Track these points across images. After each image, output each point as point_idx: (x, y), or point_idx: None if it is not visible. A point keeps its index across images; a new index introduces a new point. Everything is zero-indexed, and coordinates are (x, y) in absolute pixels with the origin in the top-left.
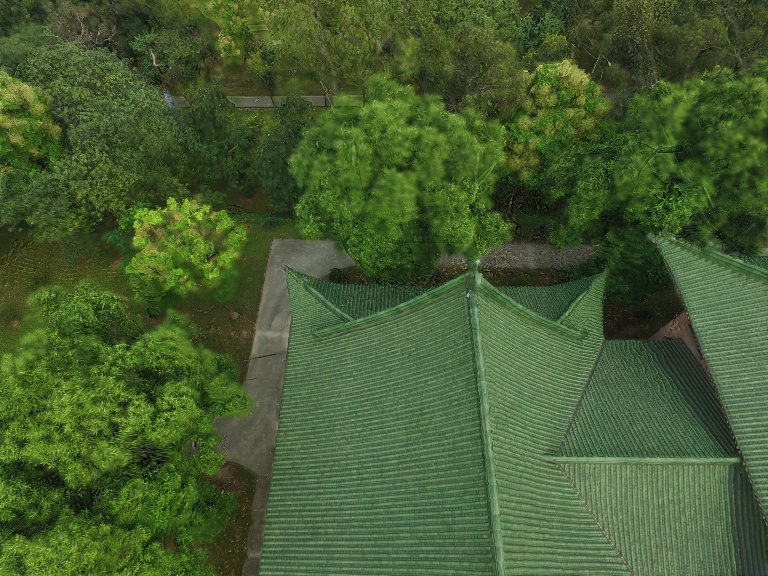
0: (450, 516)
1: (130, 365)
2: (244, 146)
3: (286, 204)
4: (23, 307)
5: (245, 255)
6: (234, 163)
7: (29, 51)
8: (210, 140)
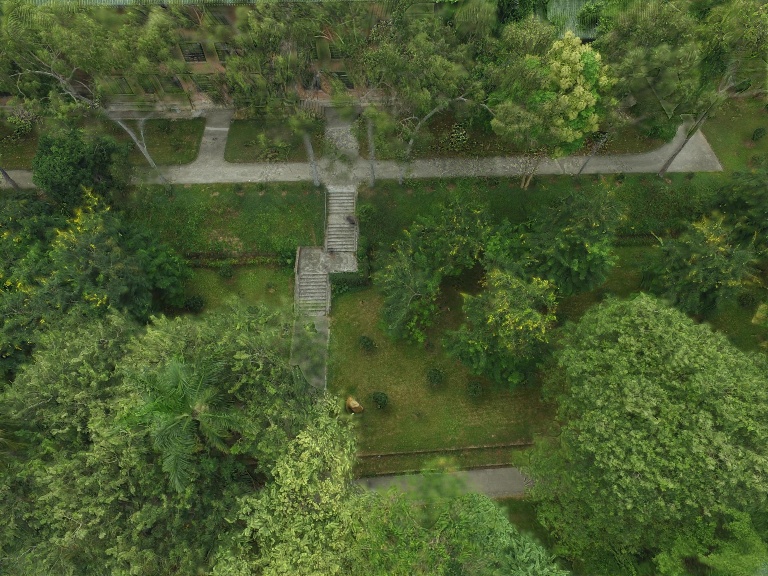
0: None
1: None
2: None
3: None
4: None
5: (737, 156)
6: None
7: None
8: None
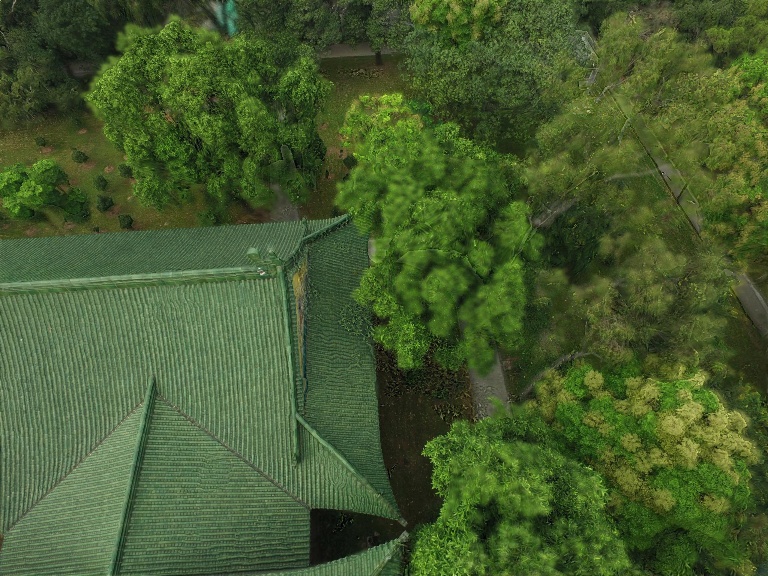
0: None
1: (231, 98)
2: None
3: None
4: None
5: None
6: None
7: None
8: (565, 154)
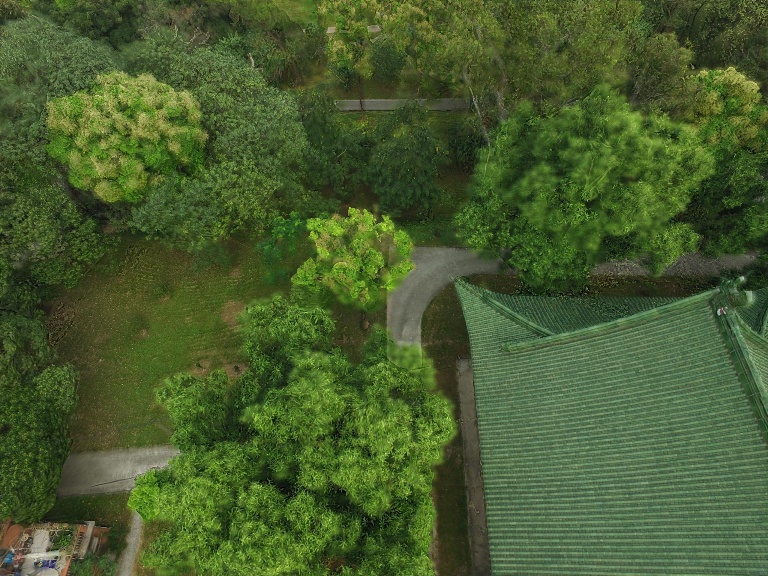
0: (746, 543)
1: (388, 385)
2: (354, 152)
3: (400, 211)
4: (149, 316)
5: None
6: (342, 169)
7: (169, 57)
8: (318, 145)
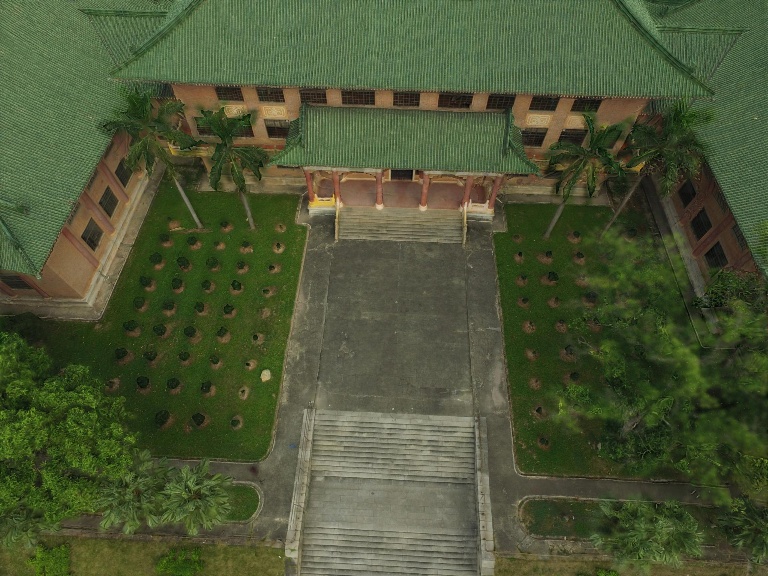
0: None
1: None
2: None
3: None
4: None
5: None
6: None
7: None
8: None
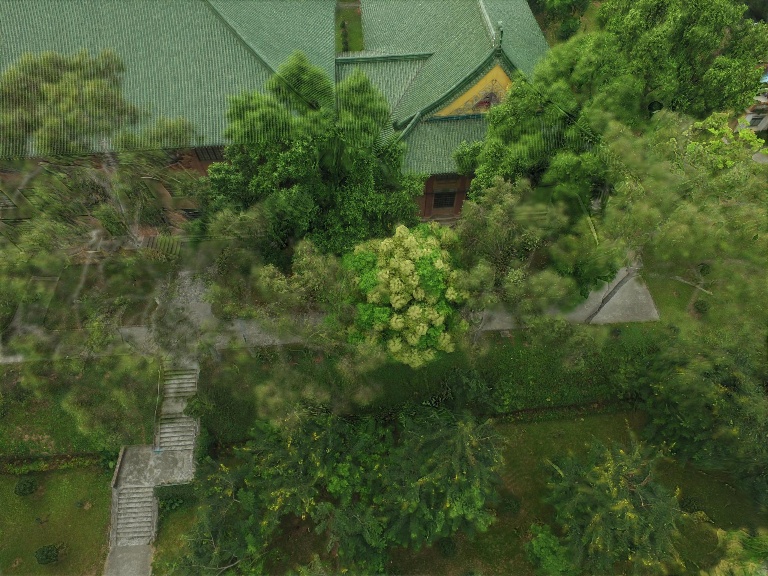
0: None
1: None
2: None
3: None
4: None
5: (677, 297)
6: None
7: None
8: None
